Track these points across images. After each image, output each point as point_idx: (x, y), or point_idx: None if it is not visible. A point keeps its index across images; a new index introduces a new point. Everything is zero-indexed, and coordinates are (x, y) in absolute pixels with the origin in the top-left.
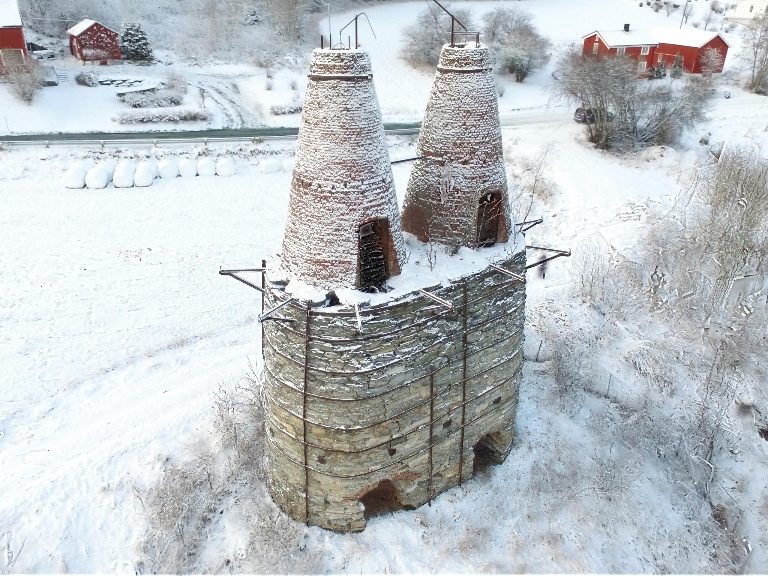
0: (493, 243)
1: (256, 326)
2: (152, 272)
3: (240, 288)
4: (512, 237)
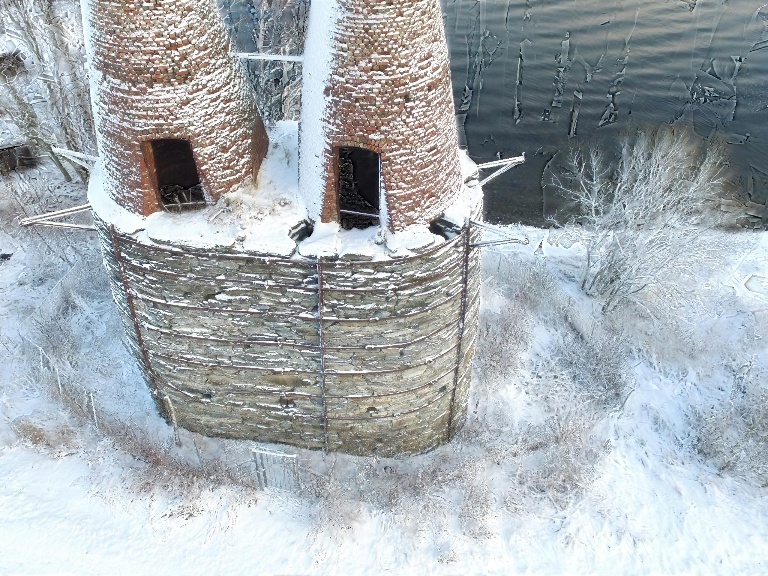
0: (163, 159)
1: None
2: None
3: None
4: None
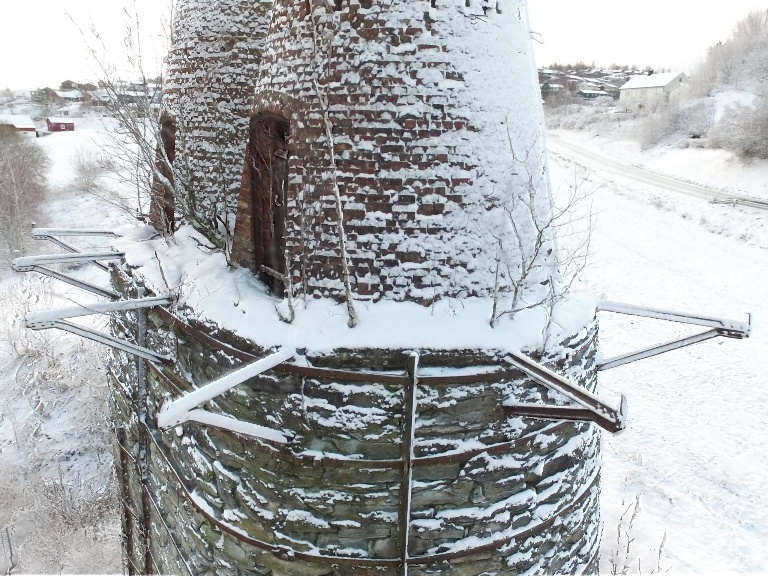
0: None
1: (628, 471)
2: (671, 358)
3: (711, 432)
4: (307, 303)
